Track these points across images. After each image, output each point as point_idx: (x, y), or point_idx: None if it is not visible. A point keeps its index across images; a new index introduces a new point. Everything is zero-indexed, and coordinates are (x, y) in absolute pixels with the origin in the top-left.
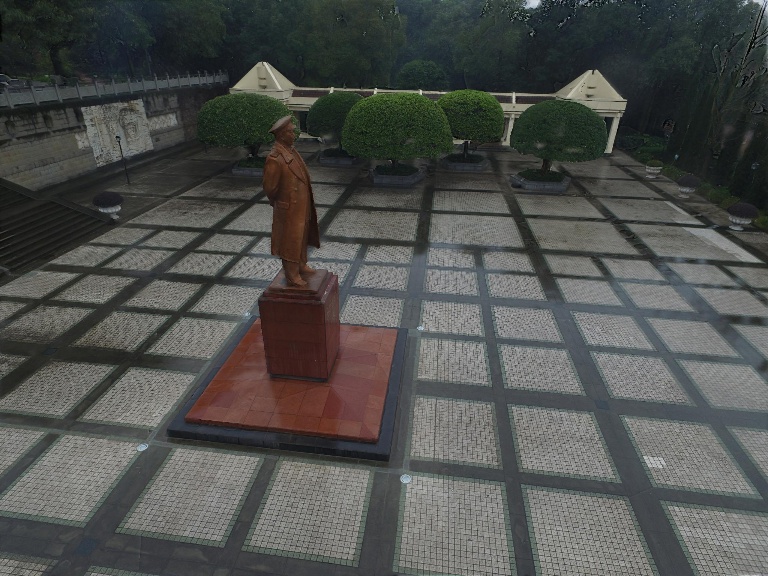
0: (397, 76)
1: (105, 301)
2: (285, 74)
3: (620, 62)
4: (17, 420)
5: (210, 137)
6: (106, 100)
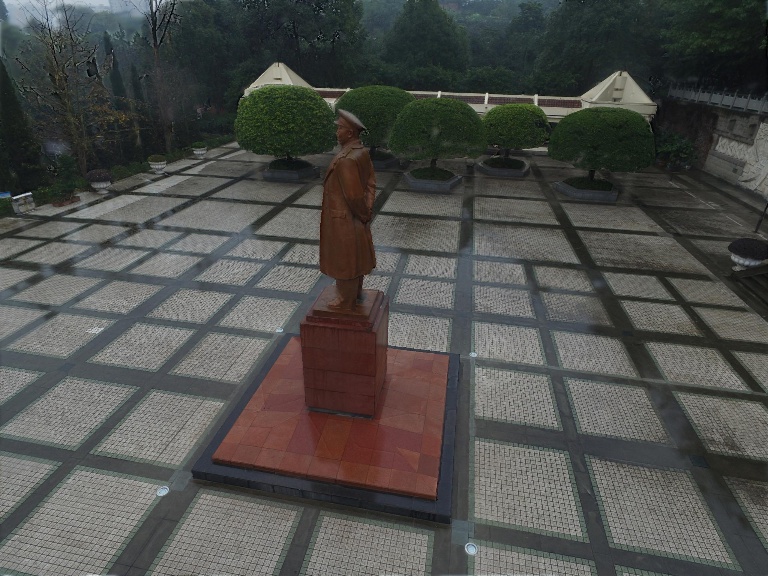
0: None
1: None
2: None
3: None
4: (601, 377)
5: None
6: None
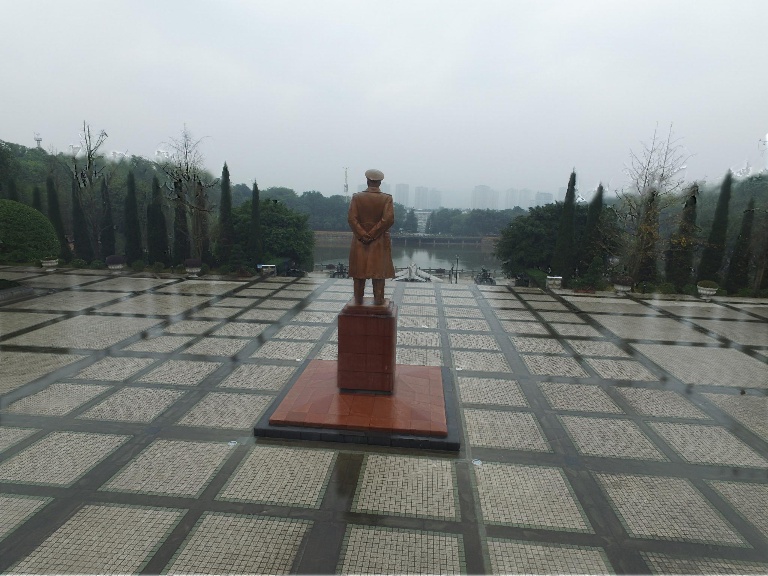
0: None
1: None
2: None
3: None
4: None
5: None
6: None
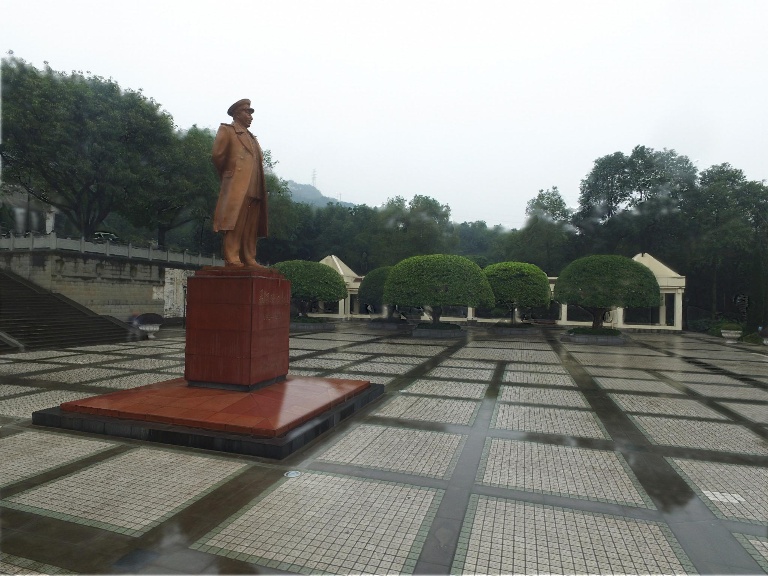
0: None
1: (85, 363)
2: (350, 266)
3: (669, 246)
4: None
5: None
6: (189, 267)
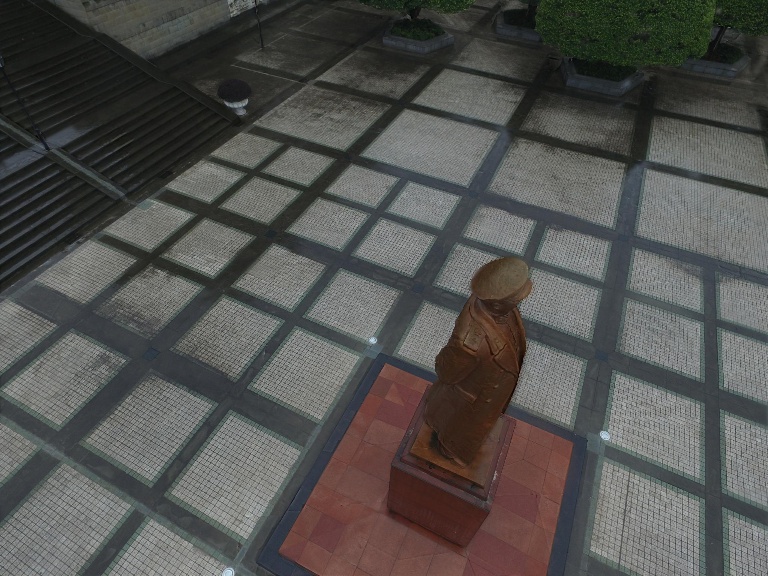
0: None
1: (216, 273)
2: None
3: None
4: (107, 473)
5: None
6: None
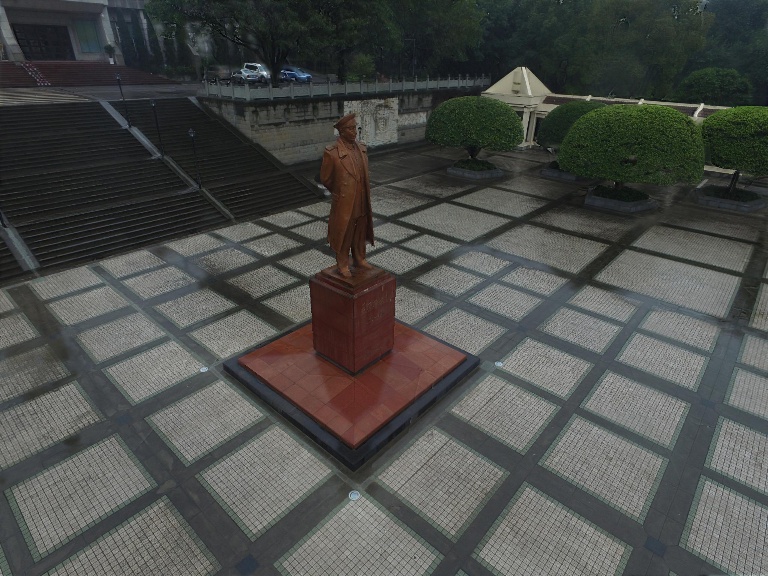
0: (678, 86)
1: (269, 256)
2: (543, 80)
3: None
4: (160, 320)
5: (433, 135)
6: (366, 96)
